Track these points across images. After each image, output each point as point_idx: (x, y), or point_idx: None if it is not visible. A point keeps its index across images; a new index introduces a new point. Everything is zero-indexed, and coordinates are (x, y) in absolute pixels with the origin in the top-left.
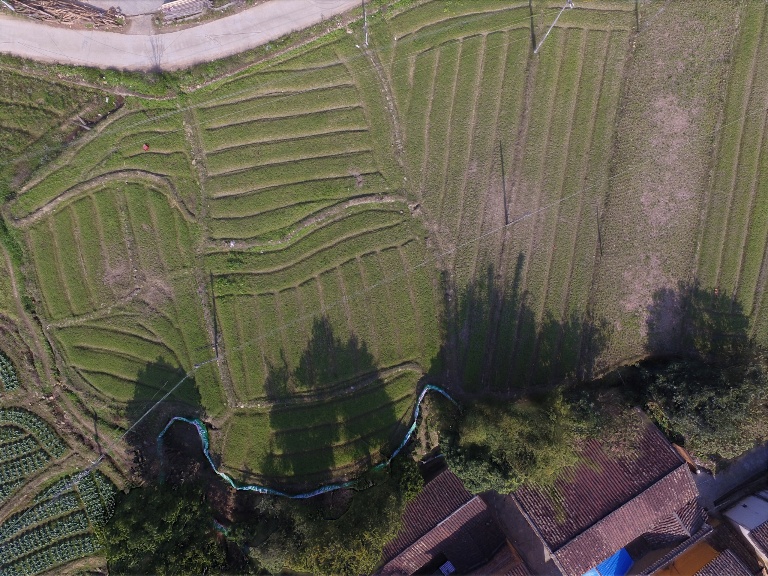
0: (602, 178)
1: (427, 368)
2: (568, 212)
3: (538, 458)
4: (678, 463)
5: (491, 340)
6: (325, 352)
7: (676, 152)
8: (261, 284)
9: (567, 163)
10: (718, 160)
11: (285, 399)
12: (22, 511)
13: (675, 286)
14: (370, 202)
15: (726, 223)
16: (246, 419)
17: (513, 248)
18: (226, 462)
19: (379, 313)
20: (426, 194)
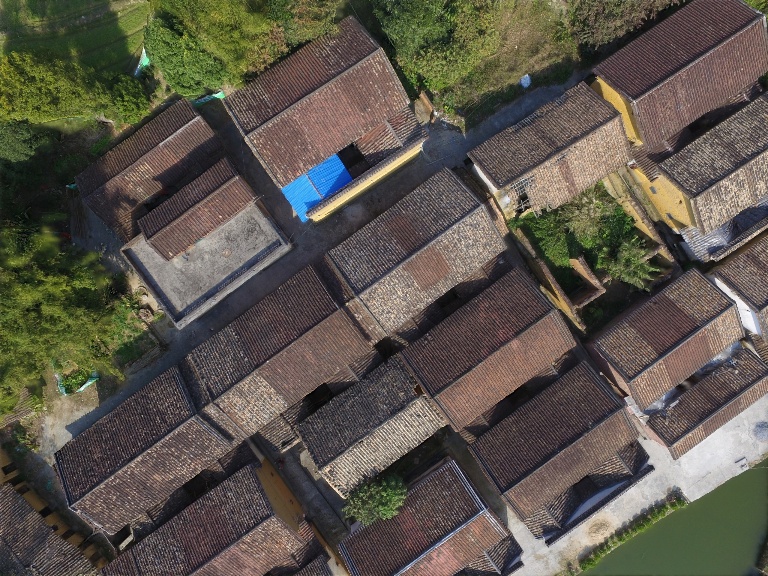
0: None
1: None
2: None
3: None
4: (374, 50)
5: None
6: None
7: None
8: None
9: None
10: None
11: (16, 27)
12: None
13: None
14: None
15: None
16: None
17: None
18: None
19: None
20: None
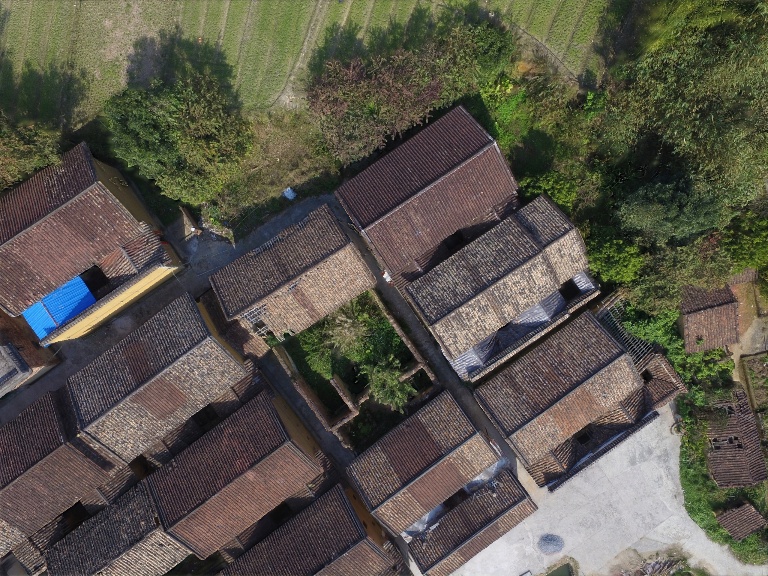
0: None
1: None
2: None
3: None
4: (91, 183)
5: None
6: None
7: None
8: None
9: None
10: None
11: None
12: None
13: (156, 34)
14: None
15: None
16: None
17: None
18: None
19: None
20: None
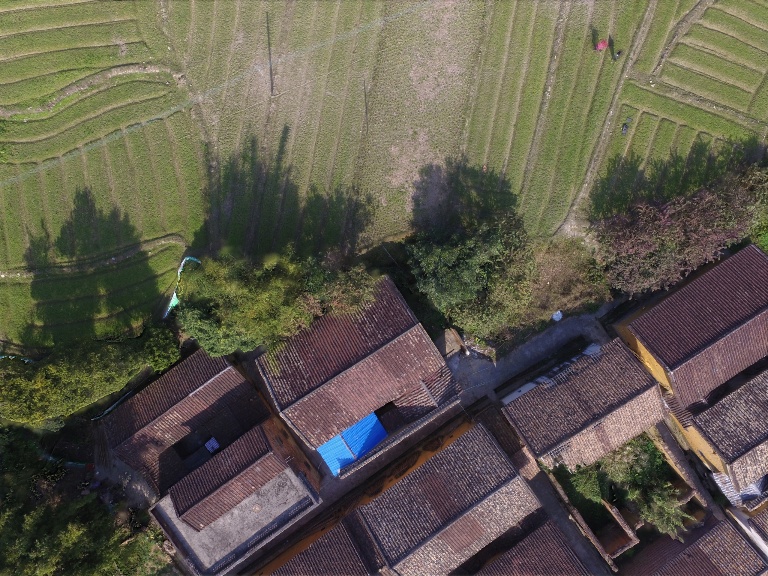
0: (370, 52)
1: (190, 241)
2: (334, 85)
3: (239, 301)
4: (411, 325)
5: (254, 213)
6: (87, 222)
7: (446, 27)
8: (23, 153)
9: (335, 36)
10: (490, 36)
11: (45, 268)
12: None
13: (442, 162)
14: (134, 72)
15: (497, 100)
16: (6, 288)
17: (278, 121)
18: None
19: (142, 184)
20: (190, 64)
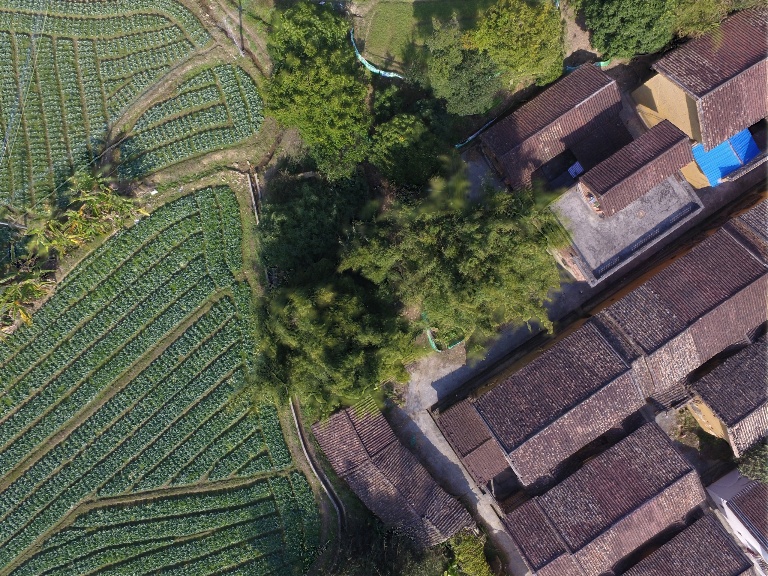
0: None
1: None
2: None
3: None
4: None
5: None
6: None
7: None
8: None
9: None
10: None
11: None
12: (164, 101)
13: None
14: None
15: None
16: (391, 6)
17: None
18: (369, 48)
19: None
20: None
